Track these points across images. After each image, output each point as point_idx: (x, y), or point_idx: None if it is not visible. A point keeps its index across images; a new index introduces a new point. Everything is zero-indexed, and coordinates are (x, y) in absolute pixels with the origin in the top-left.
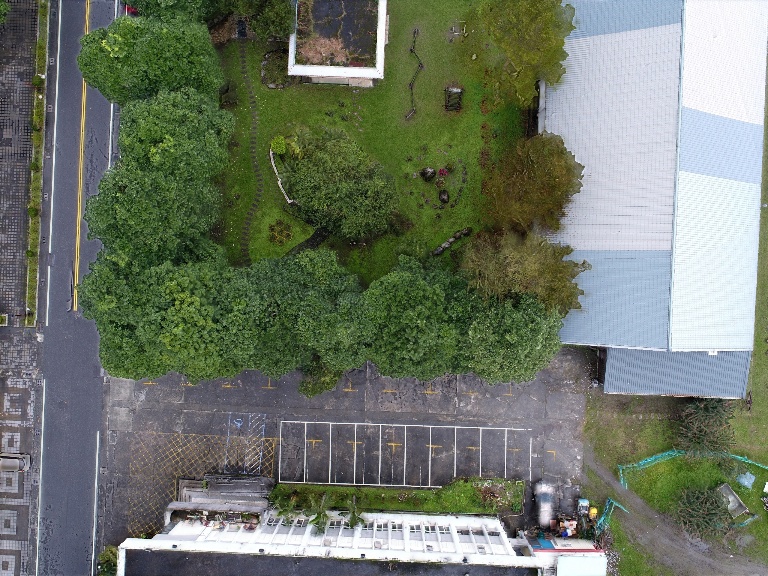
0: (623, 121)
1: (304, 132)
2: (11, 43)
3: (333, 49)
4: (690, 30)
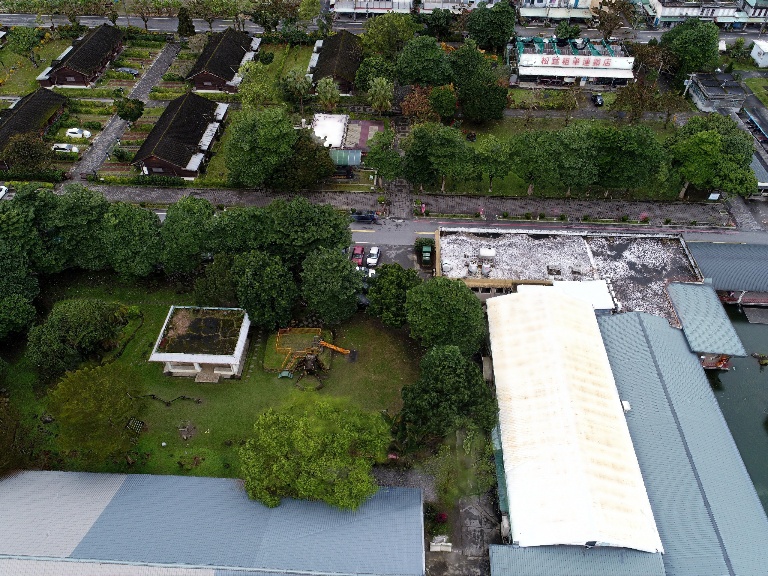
0: (7, 518)
1: (117, 306)
2: (250, 199)
3: (180, 329)
4: (59, 570)
